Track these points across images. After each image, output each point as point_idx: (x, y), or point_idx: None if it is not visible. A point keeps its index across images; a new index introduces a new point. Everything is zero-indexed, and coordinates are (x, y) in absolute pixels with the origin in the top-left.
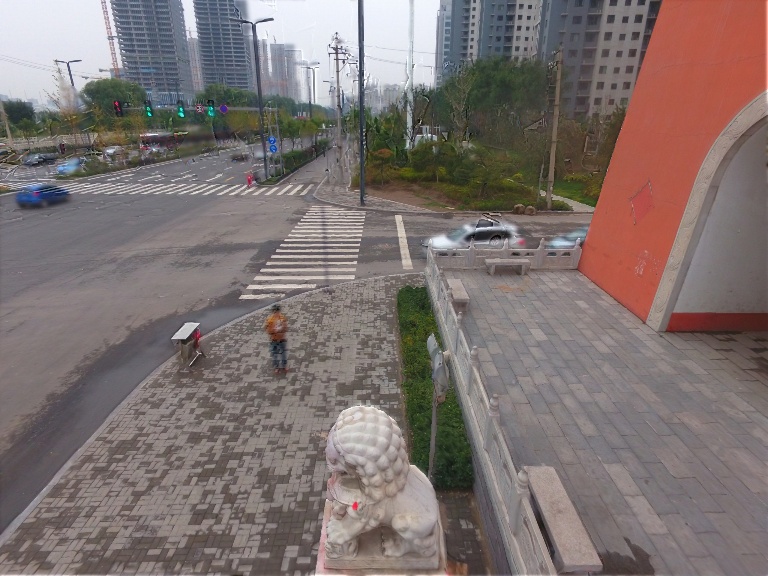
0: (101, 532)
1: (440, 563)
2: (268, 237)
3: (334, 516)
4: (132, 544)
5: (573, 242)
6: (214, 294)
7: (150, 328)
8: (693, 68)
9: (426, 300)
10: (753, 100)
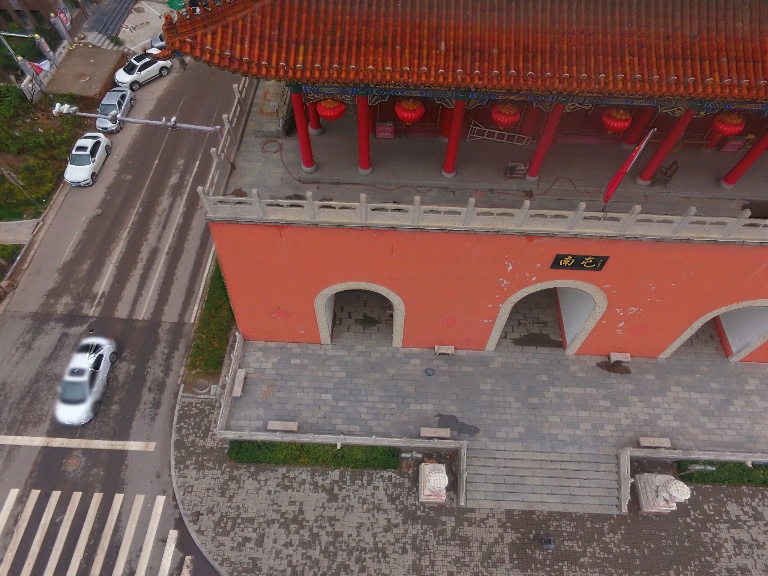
0: None
1: None
2: None
3: (439, 492)
4: (415, 572)
5: (127, 293)
6: None
7: None
8: None
9: (256, 443)
10: (329, 287)
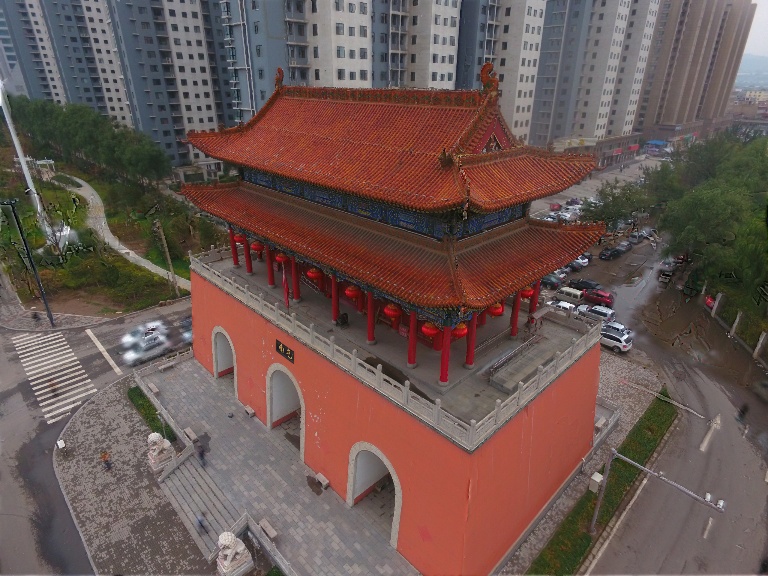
0: (93, 490)
1: (173, 450)
2: (15, 381)
3: None
4: None
5: None
6: (31, 428)
7: (22, 453)
8: (203, 309)
9: (141, 393)
10: (215, 327)
